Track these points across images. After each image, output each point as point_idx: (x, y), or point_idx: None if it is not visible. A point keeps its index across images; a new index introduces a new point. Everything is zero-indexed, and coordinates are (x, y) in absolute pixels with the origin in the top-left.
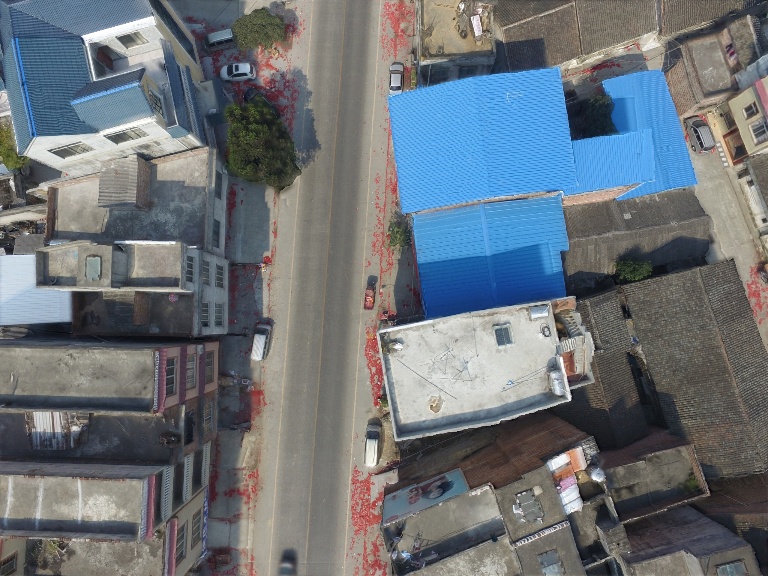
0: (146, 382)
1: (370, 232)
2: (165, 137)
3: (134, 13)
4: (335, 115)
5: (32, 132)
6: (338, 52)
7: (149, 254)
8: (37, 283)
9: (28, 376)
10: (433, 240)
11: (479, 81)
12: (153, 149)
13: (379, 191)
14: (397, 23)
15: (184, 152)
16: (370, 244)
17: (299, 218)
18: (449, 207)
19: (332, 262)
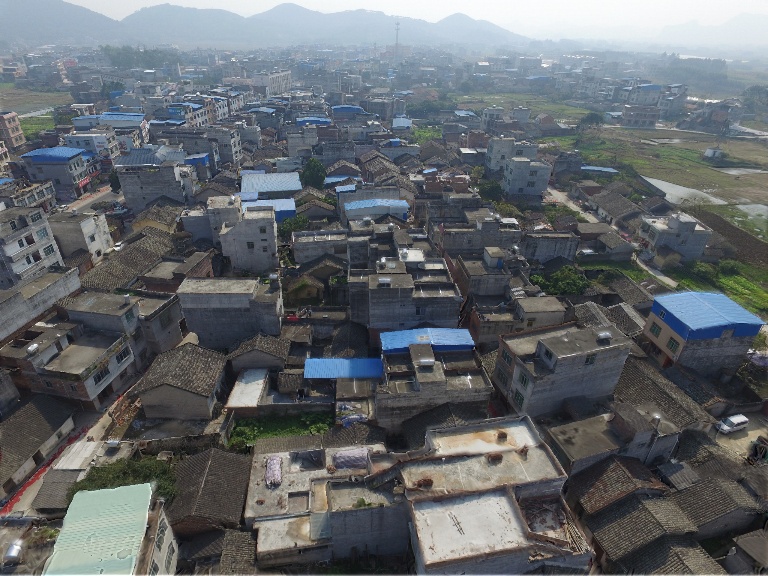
0: None
1: None
2: None
3: None
4: None
5: (163, 145)
6: None
7: None
8: None
9: None
10: None
11: None
12: None
13: None
14: None
15: None
16: None
17: None
18: None
19: None
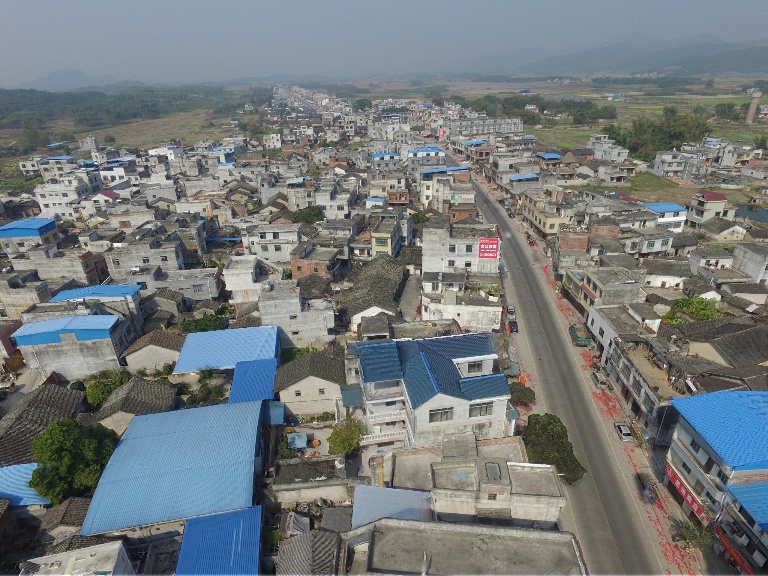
0: (567, 571)
1: (655, 541)
2: (499, 419)
3: (485, 352)
4: (582, 450)
5: (438, 390)
6: (569, 414)
7: (523, 477)
8: (434, 486)
9: (441, 556)
10: (760, 504)
11: (734, 393)
12: (483, 431)
13: (646, 507)
14: (606, 402)
15: (502, 438)
16: (660, 553)
17: (578, 524)
18: (759, 476)
19: (628, 567)
